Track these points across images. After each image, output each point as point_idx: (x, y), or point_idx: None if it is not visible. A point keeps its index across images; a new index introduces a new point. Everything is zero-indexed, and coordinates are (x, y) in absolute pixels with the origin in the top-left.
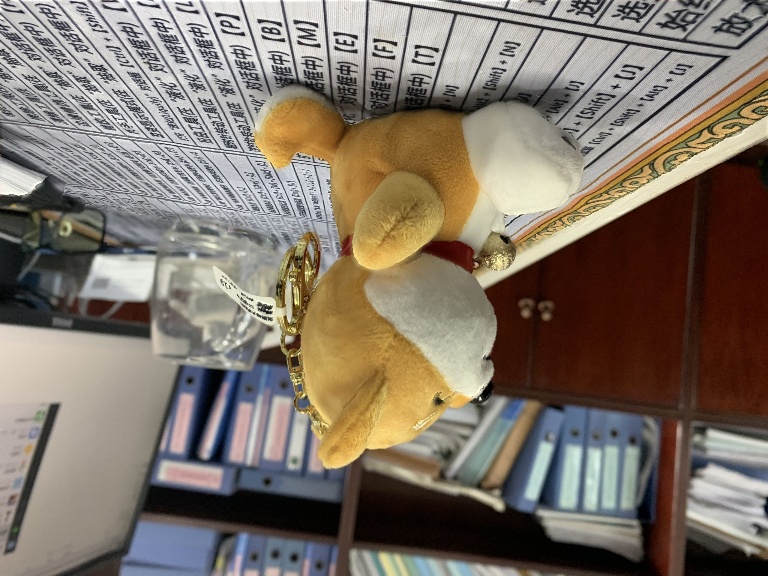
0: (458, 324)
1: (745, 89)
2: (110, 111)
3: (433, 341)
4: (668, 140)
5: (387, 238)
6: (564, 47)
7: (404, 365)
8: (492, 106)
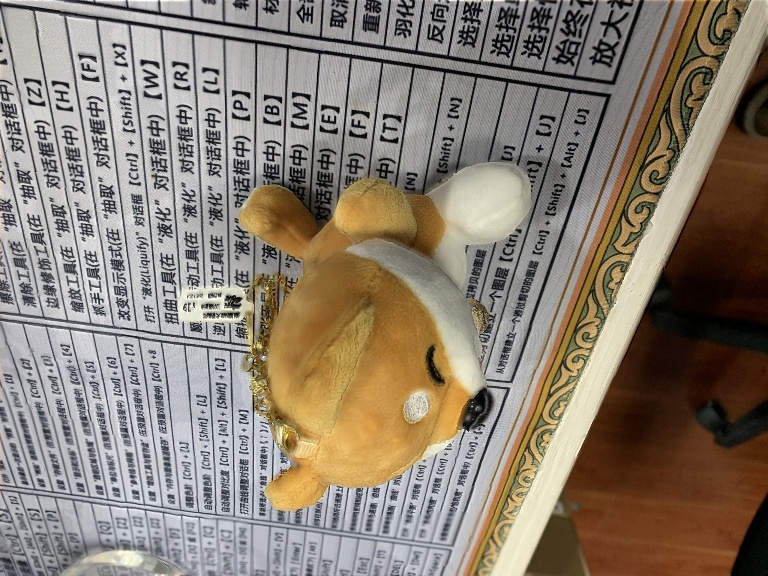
0: (444, 280)
1: (634, 144)
2: (90, 274)
3: (420, 281)
4: (597, 241)
5: (369, 190)
6: (494, 99)
7: (391, 295)
8: (446, 181)
